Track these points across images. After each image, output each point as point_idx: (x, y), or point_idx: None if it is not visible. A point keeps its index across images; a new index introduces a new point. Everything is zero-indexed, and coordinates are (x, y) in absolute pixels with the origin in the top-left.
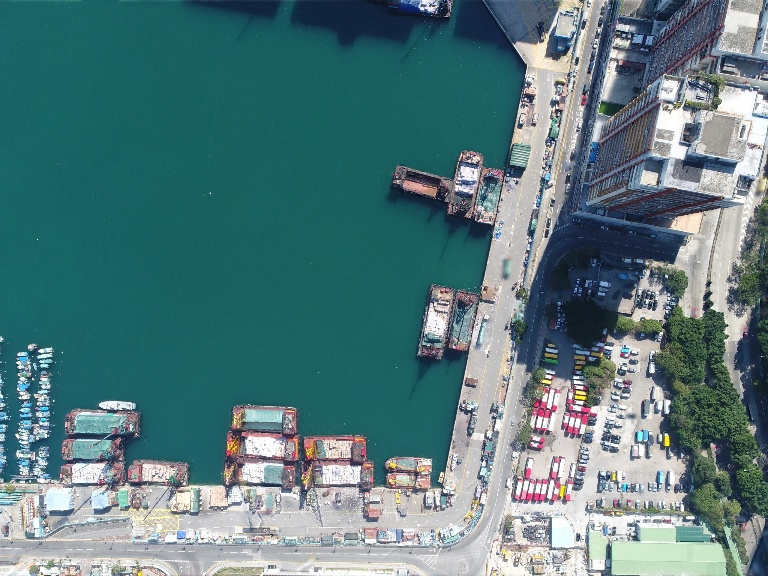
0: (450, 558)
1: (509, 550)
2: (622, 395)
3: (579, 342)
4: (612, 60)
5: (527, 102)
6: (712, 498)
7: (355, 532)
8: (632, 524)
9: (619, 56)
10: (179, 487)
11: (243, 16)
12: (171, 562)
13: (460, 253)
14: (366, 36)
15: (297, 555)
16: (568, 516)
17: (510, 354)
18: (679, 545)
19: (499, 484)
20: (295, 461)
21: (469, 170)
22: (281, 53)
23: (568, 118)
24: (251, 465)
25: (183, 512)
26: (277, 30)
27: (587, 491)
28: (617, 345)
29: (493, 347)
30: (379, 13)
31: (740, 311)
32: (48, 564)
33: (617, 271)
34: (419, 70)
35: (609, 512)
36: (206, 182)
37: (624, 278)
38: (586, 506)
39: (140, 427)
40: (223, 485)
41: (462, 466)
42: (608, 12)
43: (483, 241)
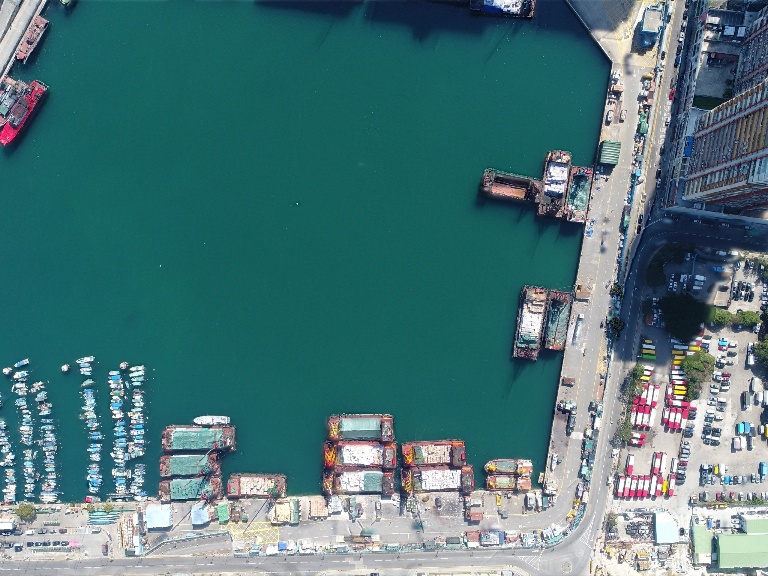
0: (553, 558)
1: (613, 547)
2: (722, 388)
3: (678, 337)
4: (703, 53)
5: (614, 99)
6: None
7: (457, 536)
8: (736, 516)
9: (710, 49)
10: (278, 499)
11: (323, 25)
12: (273, 574)
13: (551, 253)
14: (448, 40)
15: (399, 561)
16: (671, 511)
17: (606, 352)
18: None
19: (600, 482)
20: (394, 468)
21: (559, 169)
22: (363, 60)
23: (656, 113)
24: (349, 474)
25: (283, 523)
26: (357, 37)
27: (689, 485)
28: (714, 338)
29: (589, 345)
30: (460, 16)
31: None
32: None
33: (711, 264)
34: (503, 71)
35: (713, 505)
36: (292, 193)
37: (720, 271)
38: (689, 500)
39: (236, 441)
40: (321, 495)
41: (562, 466)
42: (693, 5)
43: (574, 240)
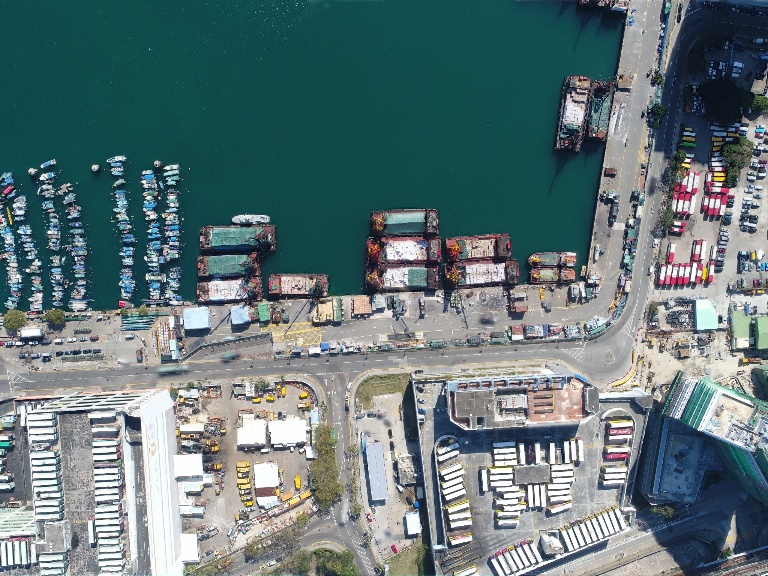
0: (596, 350)
1: (654, 337)
2: (759, 174)
3: (719, 119)
4: None
5: None
6: None
7: (501, 331)
8: None
9: None
10: (319, 298)
11: None
12: (315, 376)
13: (593, 44)
14: None
15: (444, 358)
16: (710, 299)
17: (648, 141)
18: None
19: (641, 272)
20: (437, 263)
21: None
22: None
23: None
24: (393, 270)
25: (325, 324)
26: None
27: (727, 273)
28: (751, 126)
29: (630, 136)
30: None
31: None
32: (188, 386)
33: (749, 53)
34: None
35: (750, 291)
36: None
37: (757, 58)
38: (727, 288)
39: (276, 240)
40: (364, 294)
41: (604, 257)
42: None
43: (615, 32)
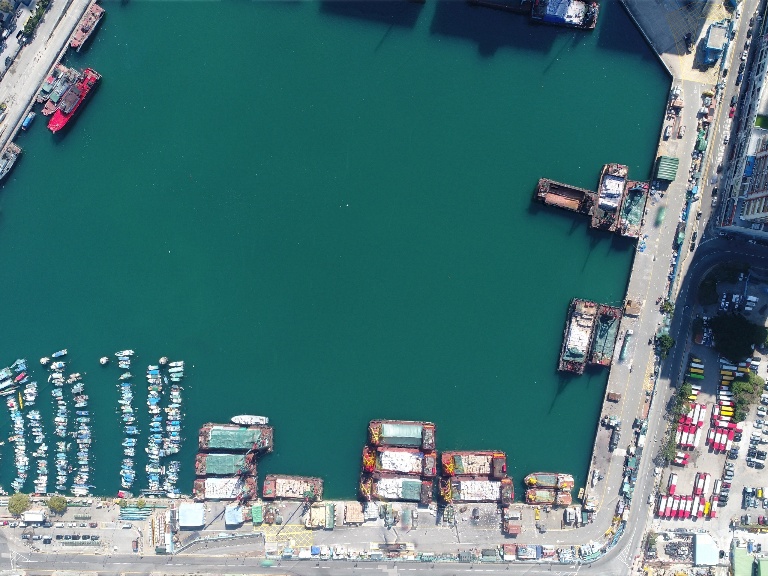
0: (590, 575)
1: (651, 567)
2: None
3: (729, 357)
4: None
5: (673, 114)
6: None
7: (493, 548)
8: None
9: None
10: (313, 502)
11: (381, 26)
12: None
13: (602, 267)
14: (508, 47)
15: (434, 571)
16: (712, 533)
17: (654, 369)
18: None
19: (641, 500)
20: (432, 476)
21: (614, 183)
22: (421, 64)
23: (715, 130)
24: (387, 480)
25: (317, 528)
26: (416, 41)
27: (731, 508)
28: (764, 360)
29: (636, 362)
30: (521, 24)
31: None
32: None
33: (764, 285)
34: (562, 81)
35: (754, 529)
36: (343, 194)
37: None
38: (730, 523)
39: (273, 442)
40: (357, 500)
41: (603, 482)
42: (757, 23)
43: (625, 254)
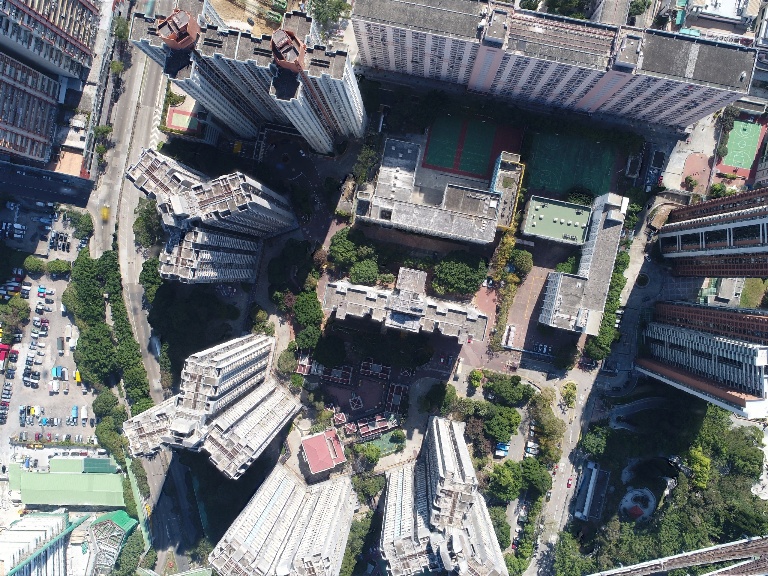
0: None
1: None
2: None
3: None
4: None
5: None
6: (109, 430)
7: None
8: (51, 457)
9: None
10: None
11: None
12: None
13: None
14: None
15: None
16: None
17: None
18: (82, 475)
19: None
20: None
21: None
22: None
23: None
24: None
25: None
26: None
27: (11, 425)
28: (35, 285)
29: None
30: None
31: (147, 253)
32: None
33: (34, 214)
34: None
35: (29, 445)
36: None
37: (36, 221)
38: None
39: None
40: None
41: None
42: None
43: None
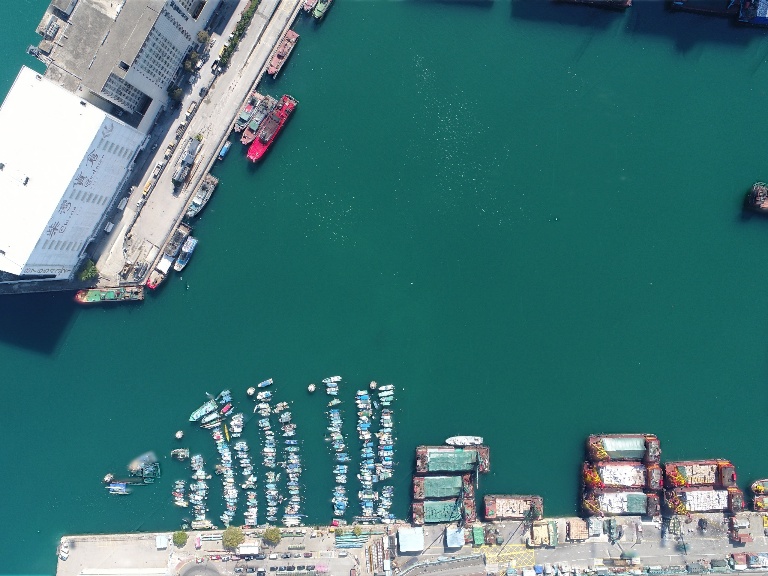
0: None
1: None
2: None
3: None
4: None
5: None
6: None
7: (721, 558)
8: None
9: None
10: (533, 521)
11: (582, 37)
12: None
13: None
14: (713, 52)
15: None
16: None
17: None
18: None
19: None
20: (656, 489)
21: None
22: (625, 73)
23: None
24: (610, 495)
25: (538, 546)
26: (617, 50)
27: None
28: None
29: None
30: (726, 28)
31: None
32: None
33: None
34: None
35: None
36: (550, 208)
37: None
38: None
39: (489, 461)
40: (578, 517)
41: None
42: None
43: None
